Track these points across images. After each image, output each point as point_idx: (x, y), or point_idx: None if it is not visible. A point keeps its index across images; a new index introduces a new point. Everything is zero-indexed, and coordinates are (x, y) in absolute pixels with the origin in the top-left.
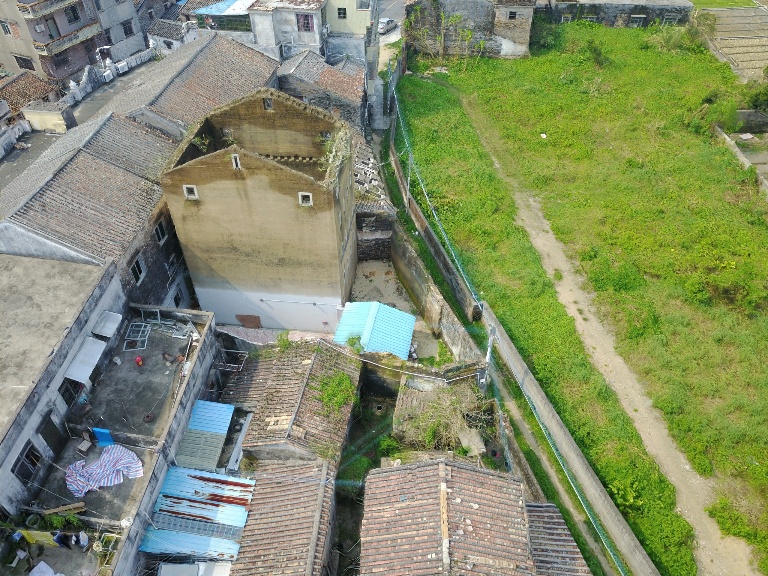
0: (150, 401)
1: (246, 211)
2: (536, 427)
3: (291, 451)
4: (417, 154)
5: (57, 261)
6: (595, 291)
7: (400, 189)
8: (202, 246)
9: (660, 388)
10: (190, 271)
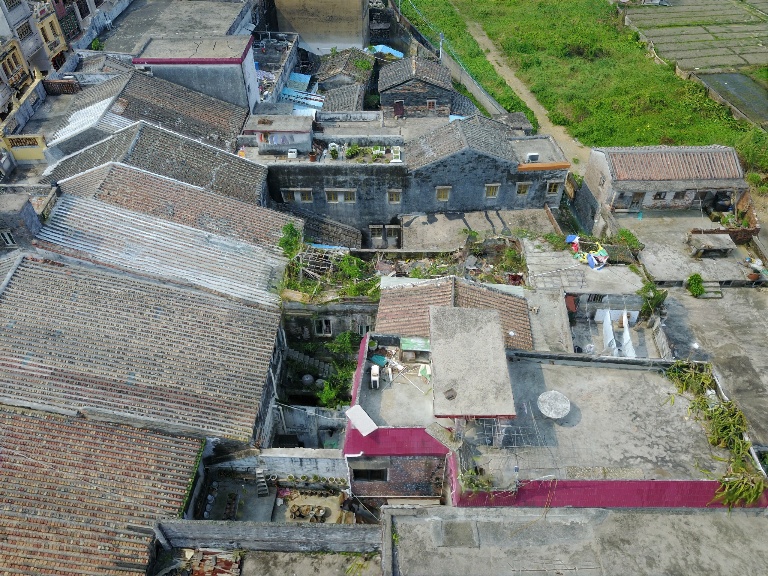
0: (272, 61)
1: None
2: (466, 95)
3: (342, 80)
4: (405, 3)
5: (220, 2)
6: (508, 56)
7: (395, 17)
8: (288, 10)
9: None
10: (279, 29)
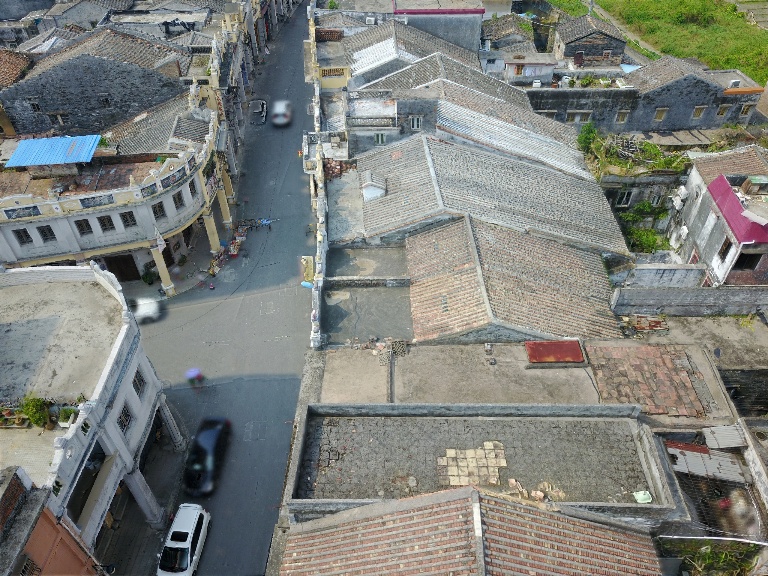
0: None
1: None
2: None
3: (515, 39)
4: None
5: None
6: (628, 24)
7: None
8: None
9: None
10: None
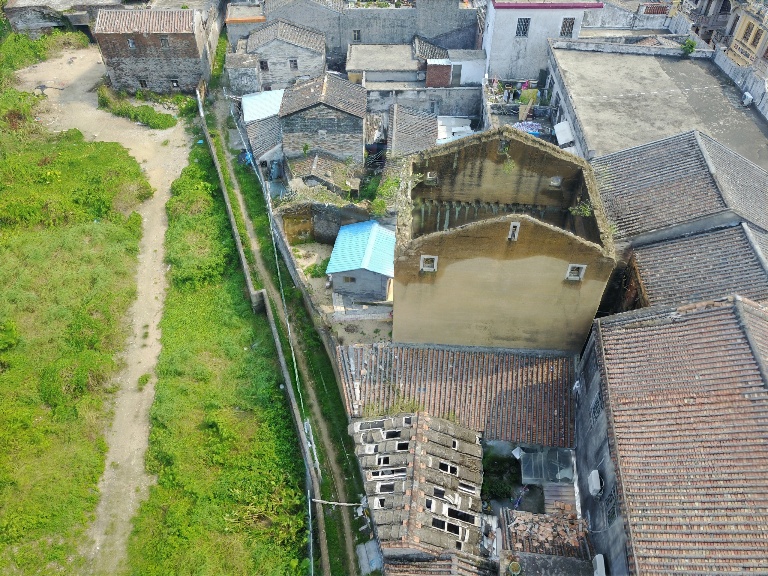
0: None
1: None
2: None
3: None
4: None
5: None
6: None
7: None
8: None
9: (125, 258)
10: None
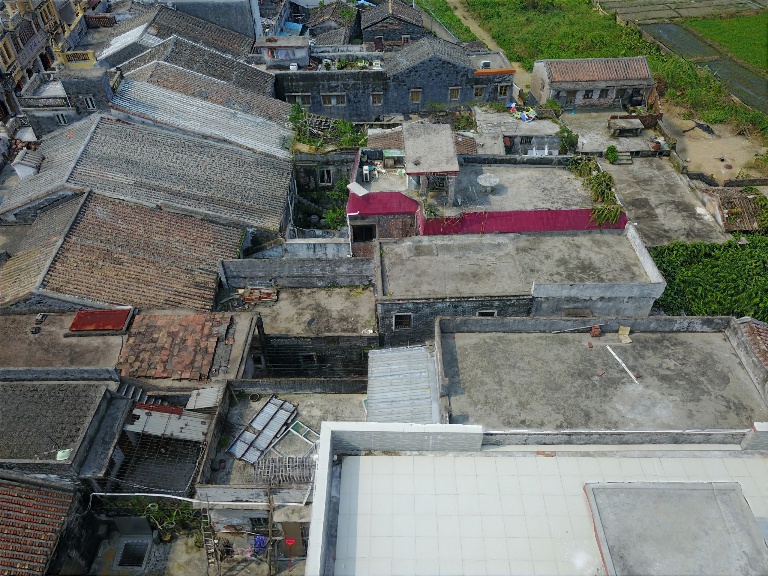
0: None
1: None
2: None
3: (330, 26)
4: None
5: None
6: (473, 12)
7: None
8: None
9: None
10: None
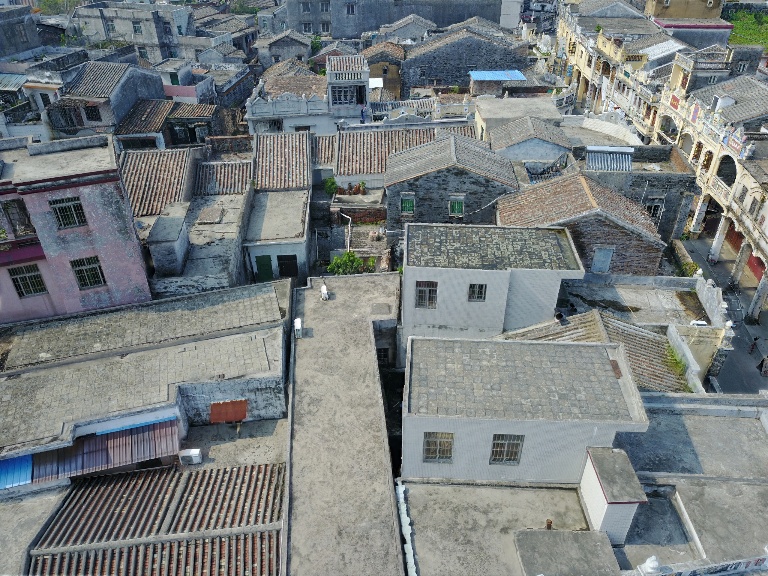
0: None
1: (684, 10)
2: None
3: None
4: None
5: (628, 18)
6: None
7: None
8: None
9: None
10: None
